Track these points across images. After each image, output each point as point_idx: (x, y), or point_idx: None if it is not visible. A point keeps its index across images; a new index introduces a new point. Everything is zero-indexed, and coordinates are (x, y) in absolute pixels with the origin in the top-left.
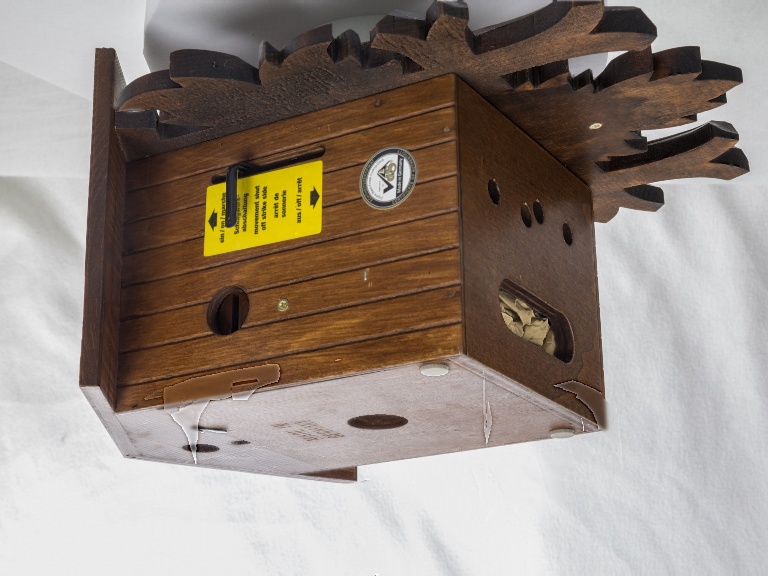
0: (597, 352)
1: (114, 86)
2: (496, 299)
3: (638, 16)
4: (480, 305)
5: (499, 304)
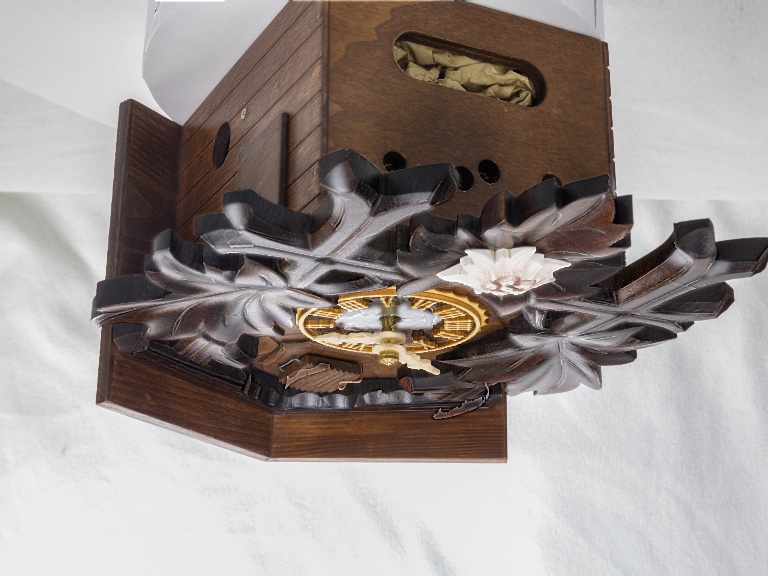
0: (337, 41)
1: (504, 424)
2: (552, 88)
3: (715, 243)
4: (580, 81)
5: (547, 84)
